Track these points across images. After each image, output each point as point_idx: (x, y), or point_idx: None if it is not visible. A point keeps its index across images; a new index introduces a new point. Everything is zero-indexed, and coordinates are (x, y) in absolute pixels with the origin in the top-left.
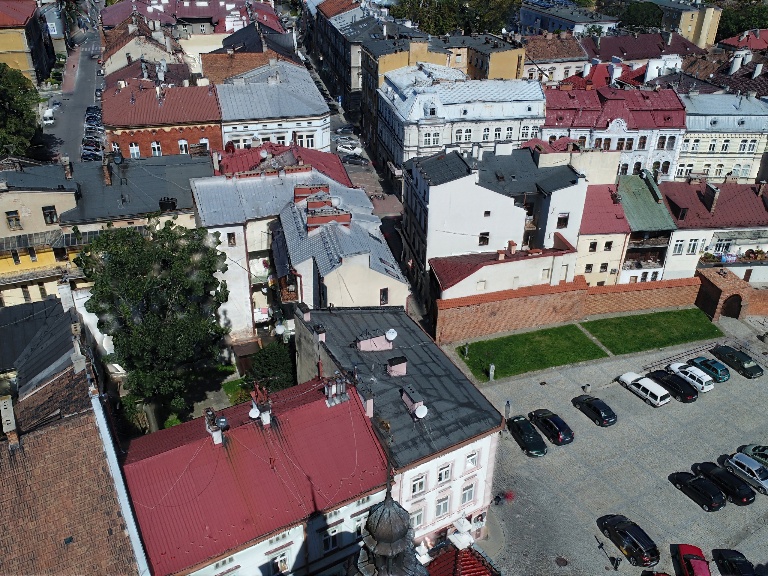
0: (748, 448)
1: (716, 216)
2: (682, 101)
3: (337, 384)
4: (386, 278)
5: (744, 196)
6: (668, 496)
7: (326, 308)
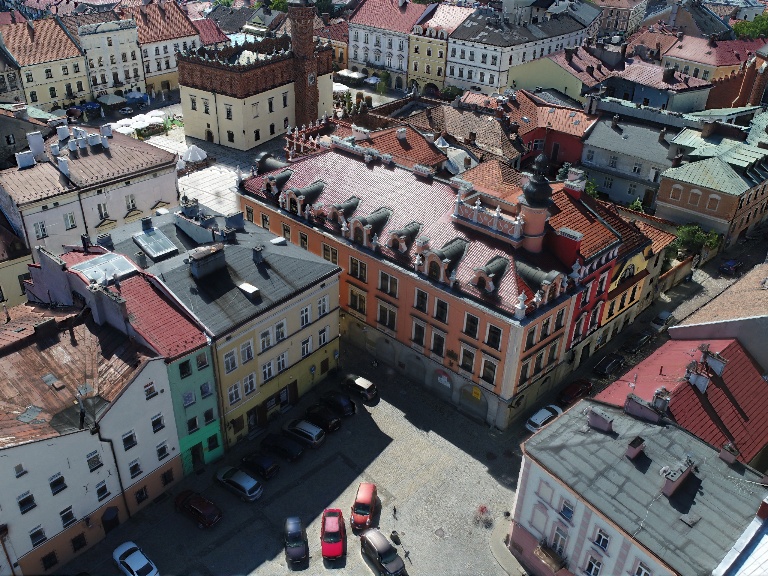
0: None
1: None
2: None
3: None
4: None
5: None
6: None
7: None
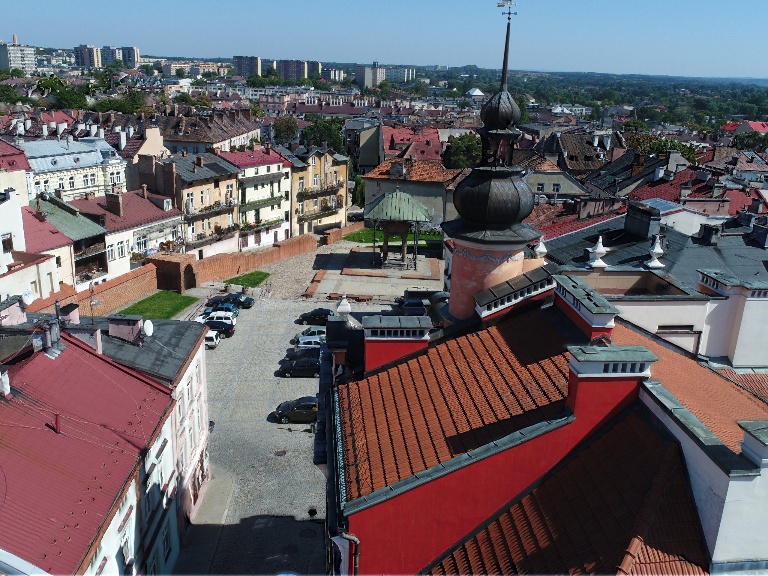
0: (299, 336)
1: (127, 218)
2: (17, 147)
3: (52, 327)
4: None
5: (135, 201)
6: (288, 384)
7: None
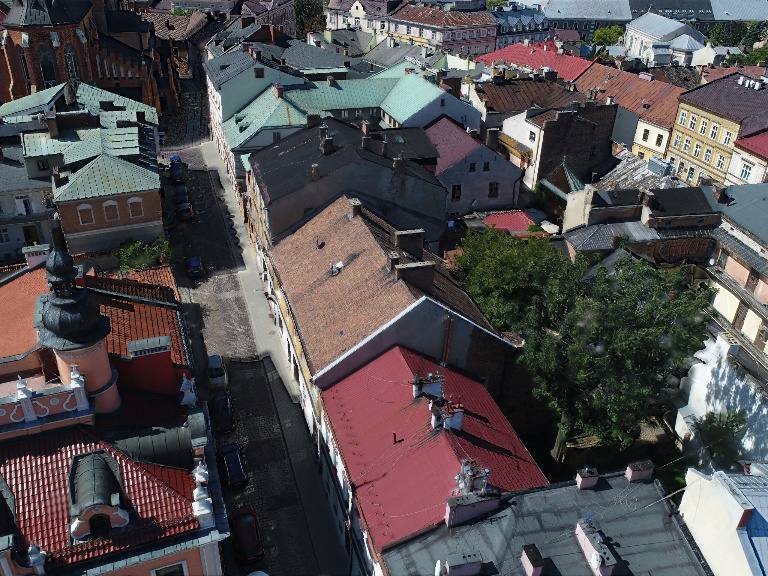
0: None
1: None
2: None
3: None
4: (750, 573)
5: None
6: None
7: (675, 507)
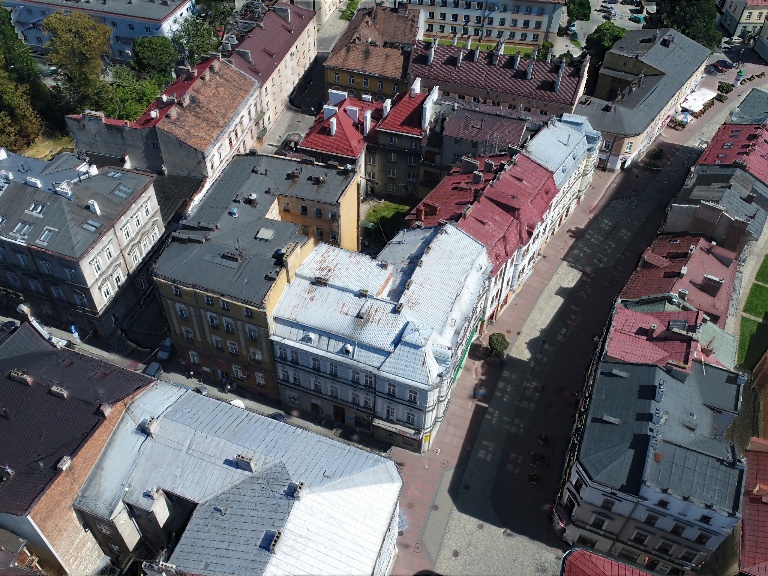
0: None
1: (719, 298)
2: (544, 166)
3: None
4: None
5: (706, 262)
6: None
7: None
